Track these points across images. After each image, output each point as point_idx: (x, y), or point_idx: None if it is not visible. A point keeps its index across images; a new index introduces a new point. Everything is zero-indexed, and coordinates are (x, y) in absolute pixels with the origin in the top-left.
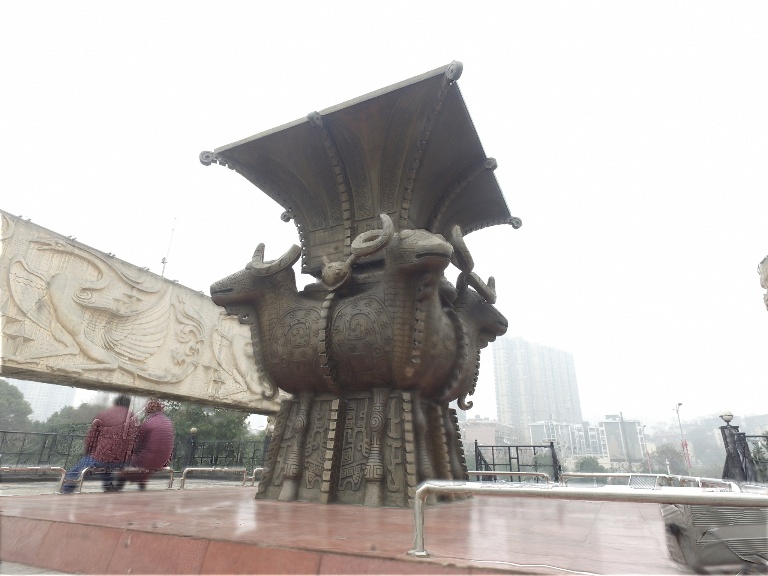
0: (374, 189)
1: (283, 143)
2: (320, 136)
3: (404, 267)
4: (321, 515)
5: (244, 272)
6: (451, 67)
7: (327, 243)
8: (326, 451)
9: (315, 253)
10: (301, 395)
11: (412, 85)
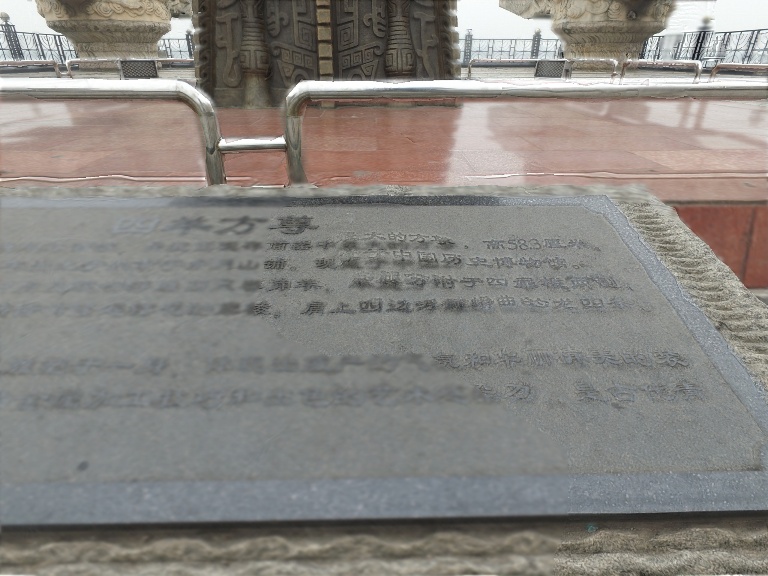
0: None
1: None
2: None
3: None
4: None
5: None
6: None
7: None
8: None
9: None
10: None
11: None
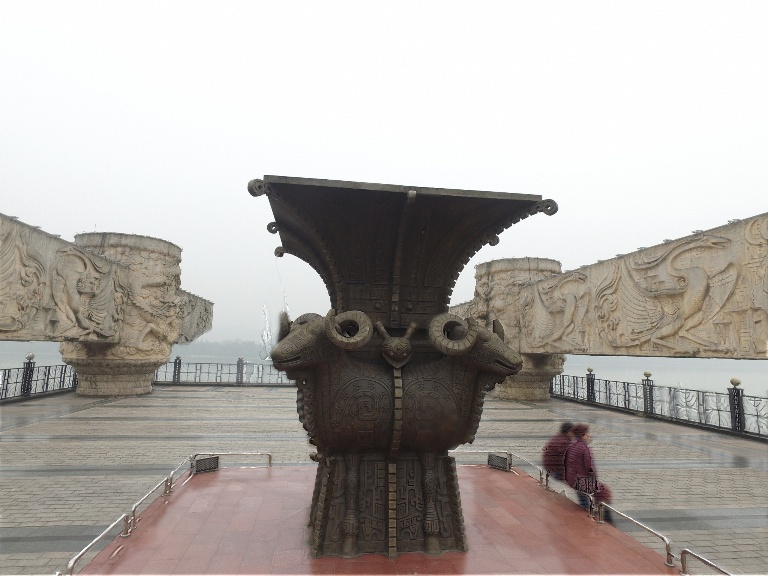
0: None
1: None
2: None
3: None
4: None
5: None
6: None
7: None
8: None
9: None
10: None
11: None
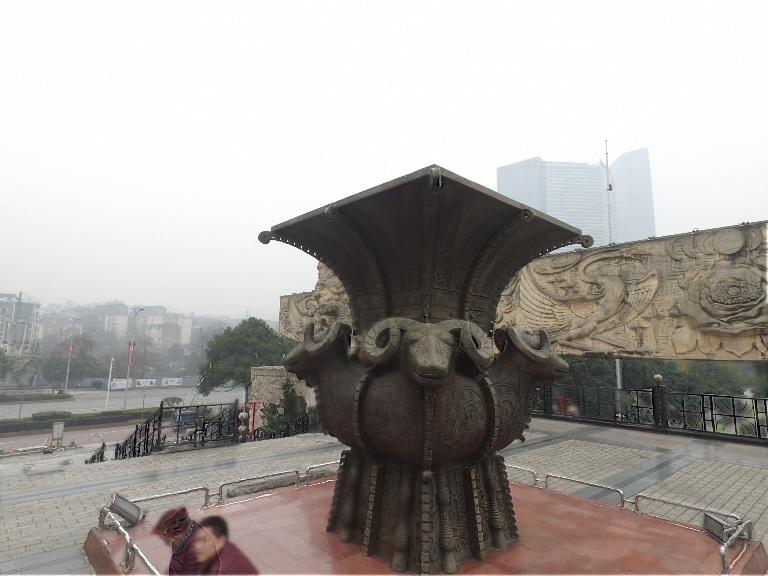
0: (488, 272)
1: (484, 205)
2: (505, 219)
3: (542, 372)
4: (576, 573)
5: (450, 349)
6: (587, 237)
7: (446, 307)
8: (477, 517)
9: (435, 314)
10: (442, 468)
11: (568, 230)
